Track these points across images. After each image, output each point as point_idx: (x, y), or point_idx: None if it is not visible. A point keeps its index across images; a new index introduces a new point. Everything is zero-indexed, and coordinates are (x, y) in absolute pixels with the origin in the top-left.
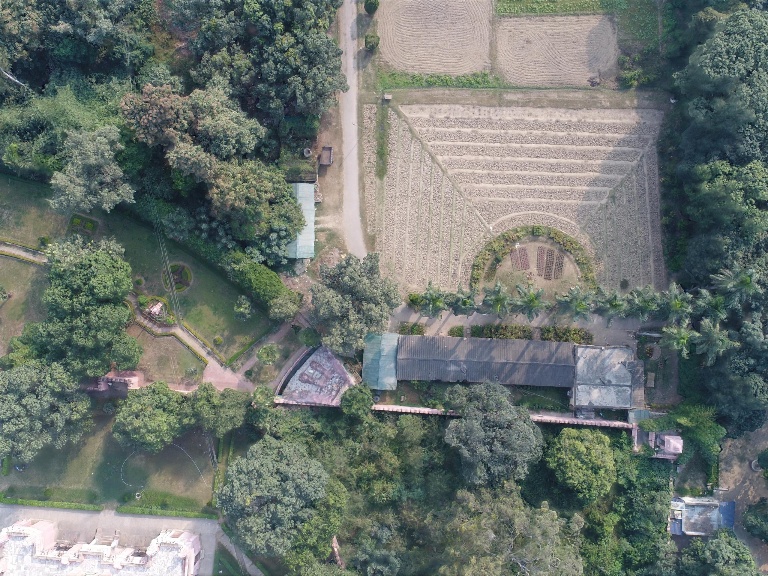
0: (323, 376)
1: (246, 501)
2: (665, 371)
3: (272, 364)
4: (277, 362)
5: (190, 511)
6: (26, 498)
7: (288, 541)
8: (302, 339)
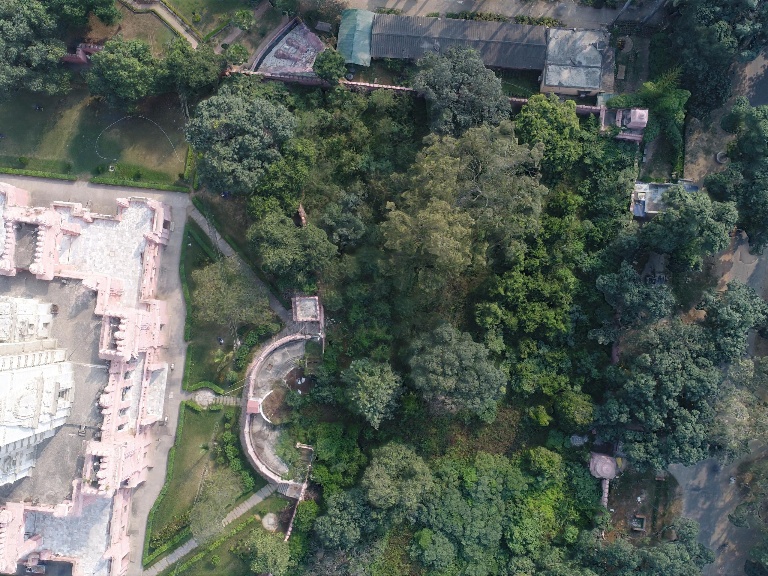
0: (298, 51)
1: (214, 124)
2: (636, 64)
3: (248, 29)
4: (254, 40)
5: (162, 184)
6: (1, 166)
7: (254, 175)
8: (278, 3)
